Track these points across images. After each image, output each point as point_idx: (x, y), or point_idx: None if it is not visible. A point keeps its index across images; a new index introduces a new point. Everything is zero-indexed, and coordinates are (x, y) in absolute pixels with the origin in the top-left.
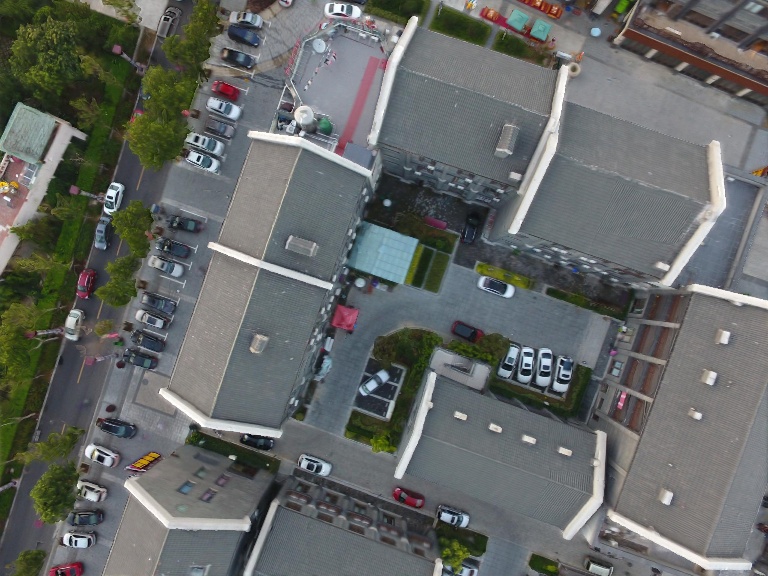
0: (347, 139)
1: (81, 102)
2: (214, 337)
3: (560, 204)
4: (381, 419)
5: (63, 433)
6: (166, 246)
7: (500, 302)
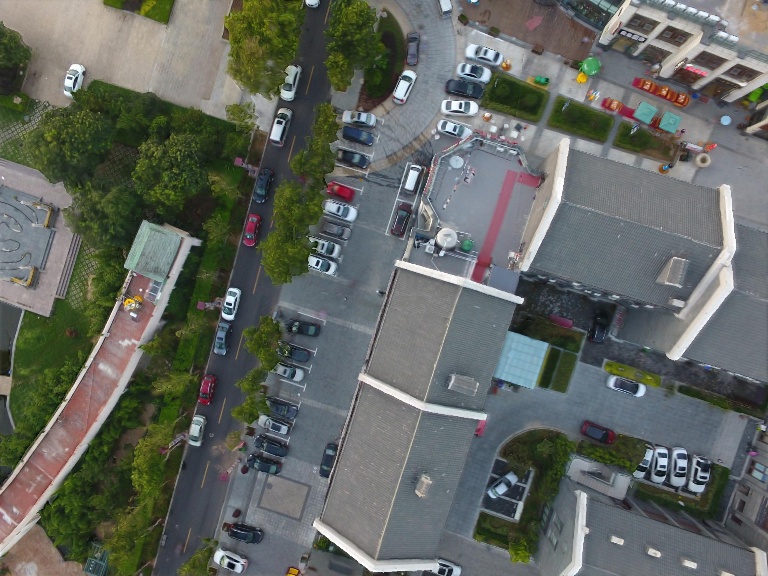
0: (486, 255)
1: (212, 224)
2: (372, 474)
3: (728, 333)
4: (510, 520)
5: (189, 537)
6: (286, 351)
7: (630, 400)
